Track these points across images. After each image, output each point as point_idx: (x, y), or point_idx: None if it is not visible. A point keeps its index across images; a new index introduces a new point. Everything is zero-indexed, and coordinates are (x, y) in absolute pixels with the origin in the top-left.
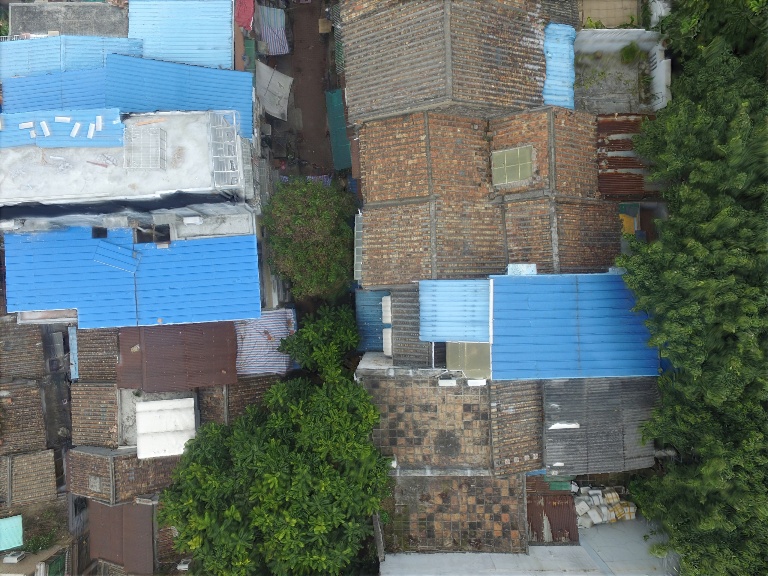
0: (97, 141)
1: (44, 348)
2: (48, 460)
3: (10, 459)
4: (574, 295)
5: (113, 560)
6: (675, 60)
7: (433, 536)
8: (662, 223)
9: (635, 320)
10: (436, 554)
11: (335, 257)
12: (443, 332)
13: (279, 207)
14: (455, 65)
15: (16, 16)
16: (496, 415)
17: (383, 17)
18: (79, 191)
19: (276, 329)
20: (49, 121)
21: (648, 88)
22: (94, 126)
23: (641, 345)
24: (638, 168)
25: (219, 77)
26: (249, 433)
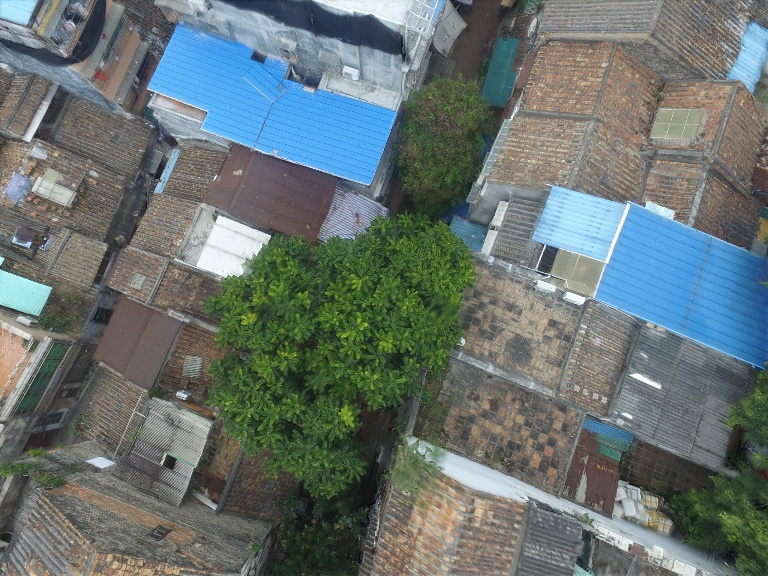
0: None
1: (143, 157)
2: (99, 252)
3: (69, 232)
4: (703, 254)
5: (114, 366)
6: None
7: (466, 438)
8: None
9: (756, 304)
10: (463, 457)
11: (459, 164)
12: (559, 239)
13: (434, 91)
14: (665, 8)
15: None
16: (582, 338)
17: None
18: None
19: (367, 217)
20: None
21: None
22: None
23: (754, 331)
24: None
25: None
26: None
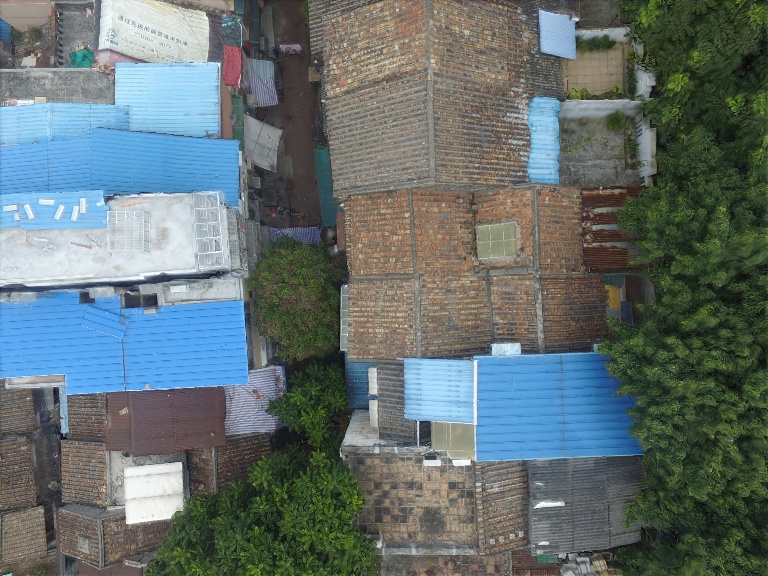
0: (81, 223)
1: (34, 402)
2: (38, 517)
3: None
4: (558, 375)
5: None
6: (660, 129)
7: None
8: (645, 309)
9: (620, 399)
10: None
11: (323, 321)
12: (428, 411)
13: (266, 276)
14: (438, 146)
15: (3, 82)
16: (481, 495)
17: (367, 94)
18: (63, 272)
19: (265, 387)
20: (33, 204)
21: (634, 154)
22: (78, 208)
23: (626, 424)
24: (623, 241)
25: (205, 146)
26: (233, 518)
